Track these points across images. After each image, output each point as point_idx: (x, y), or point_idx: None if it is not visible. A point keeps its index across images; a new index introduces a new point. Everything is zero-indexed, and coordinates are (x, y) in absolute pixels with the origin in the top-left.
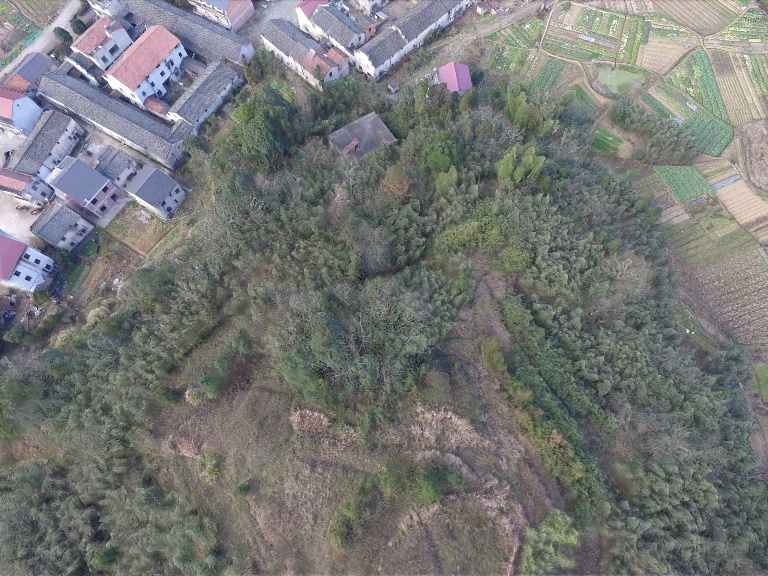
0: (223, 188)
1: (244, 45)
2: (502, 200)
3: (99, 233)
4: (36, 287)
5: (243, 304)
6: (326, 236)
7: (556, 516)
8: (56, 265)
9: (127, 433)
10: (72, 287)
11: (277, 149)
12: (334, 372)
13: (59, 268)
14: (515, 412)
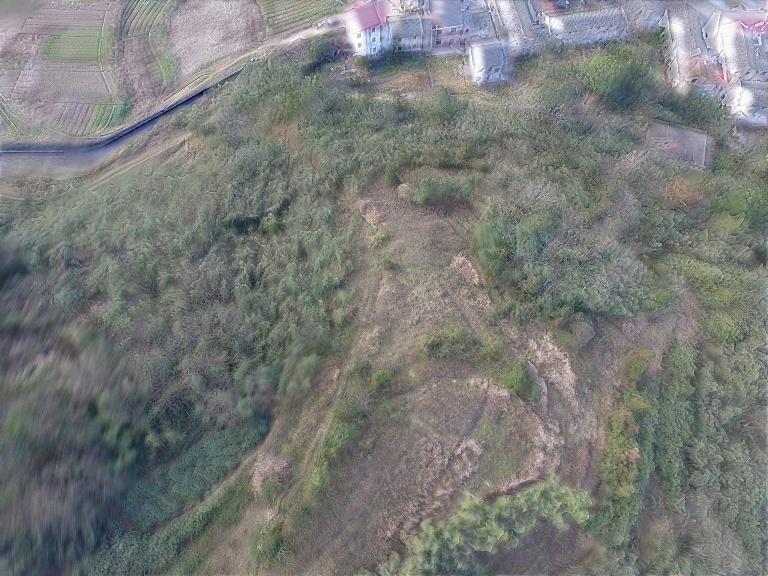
0: (546, 83)
1: (645, 7)
2: (759, 276)
3: (420, 56)
4: (358, 55)
5: (485, 167)
6: (585, 178)
7: (583, 492)
8: (379, 53)
9: (346, 175)
10: (375, 75)
11: (604, 93)
12: (516, 254)
13: (380, 56)
14: (615, 411)
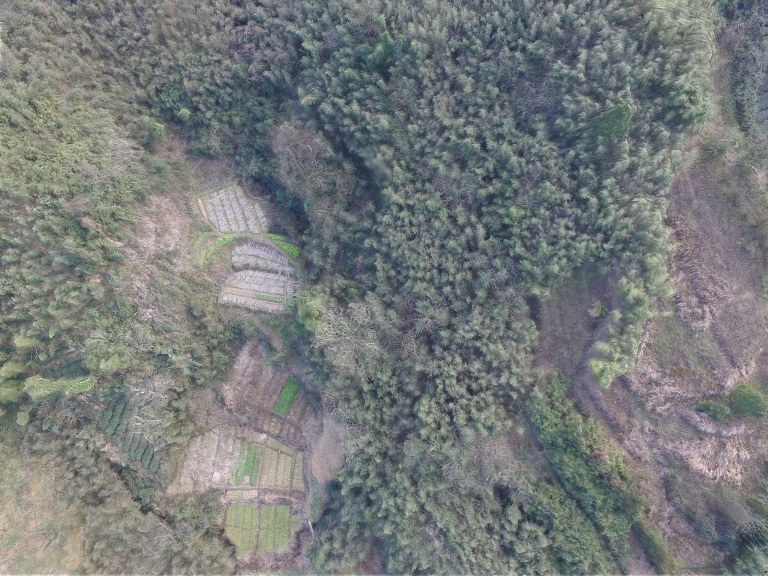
0: None
1: None
2: None
3: None
4: None
5: None
6: None
7: None
8: None
9: None
10: None
11: None
12: None
13: None
14: None
